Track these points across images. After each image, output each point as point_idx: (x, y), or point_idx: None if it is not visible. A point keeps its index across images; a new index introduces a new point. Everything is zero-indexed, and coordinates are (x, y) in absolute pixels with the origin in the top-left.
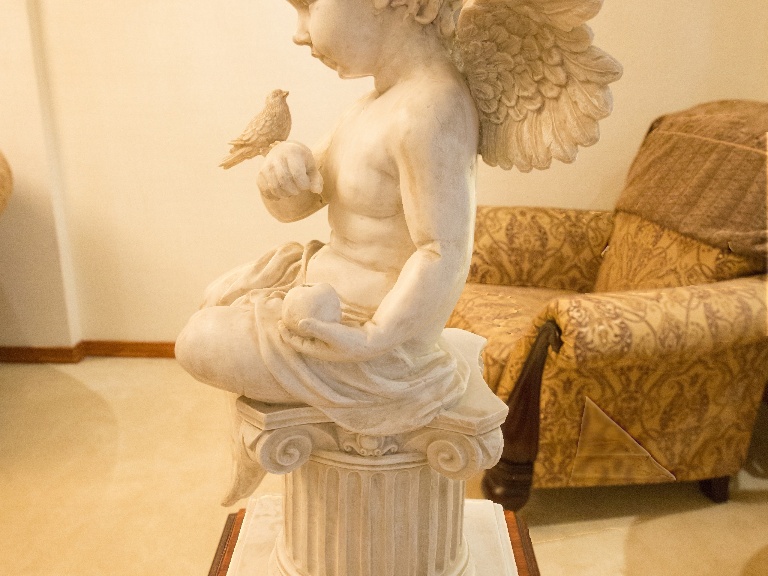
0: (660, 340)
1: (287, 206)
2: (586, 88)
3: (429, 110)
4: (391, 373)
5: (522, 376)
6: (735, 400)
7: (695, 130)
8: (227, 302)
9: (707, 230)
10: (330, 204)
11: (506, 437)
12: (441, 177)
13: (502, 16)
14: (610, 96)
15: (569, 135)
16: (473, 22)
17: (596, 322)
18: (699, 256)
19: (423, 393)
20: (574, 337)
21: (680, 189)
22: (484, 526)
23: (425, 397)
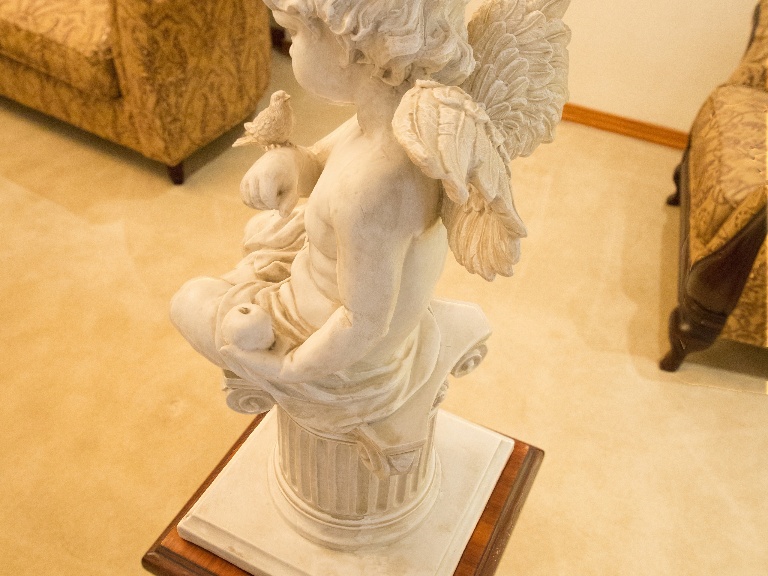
0: None
1: None
2: (501, 227)
3: (356, 197)
4: (326, 382)
5: (746, 228)
6: None
7: None
8: (249, 249)
9: None
10: None
11: (708, 282)
12: (360, 259)
13: None
14: (516, 248)
15: None
16: None
17: None
18: None
19: (352, 405)
20: None
21: None
22: (475, 463)
23: (352, 409)
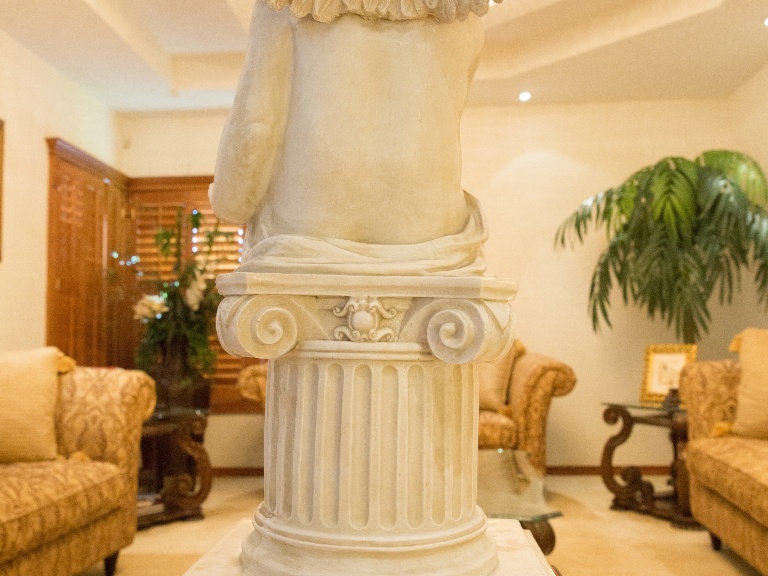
0: None
1: None
2: None
3: None
4: None
5: None
6: None
7: None
8: None
9: None
10: None
11: None
12: None
13: None
14: None
15: None
16: None
17: None
18: None
19: None
20: None
21: None
22: None
23: None
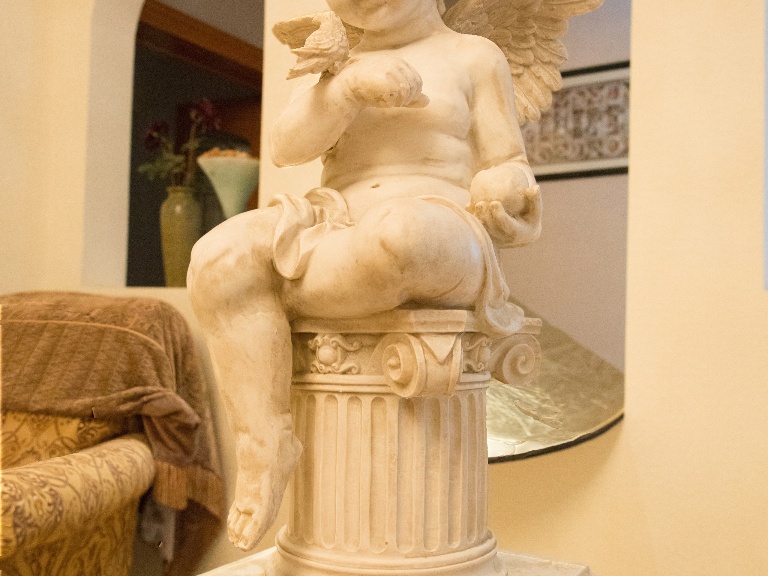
0: (84, 503)
1: (339, 133)
2: (547, 68)
3: None
4: None
5: None
6: (118, 568)
7: (8, 316)
8: (284, 239)
9: (64, 402)
10: (375, 137)
11: None
12: None
13: (495, 5)
14: None
15: (536, 100)
16: (484, 2)
17: (28, 493)
18: (58, 430)
19: None
20: (12, 514)
21: (15, 370)
22: None
23: None
